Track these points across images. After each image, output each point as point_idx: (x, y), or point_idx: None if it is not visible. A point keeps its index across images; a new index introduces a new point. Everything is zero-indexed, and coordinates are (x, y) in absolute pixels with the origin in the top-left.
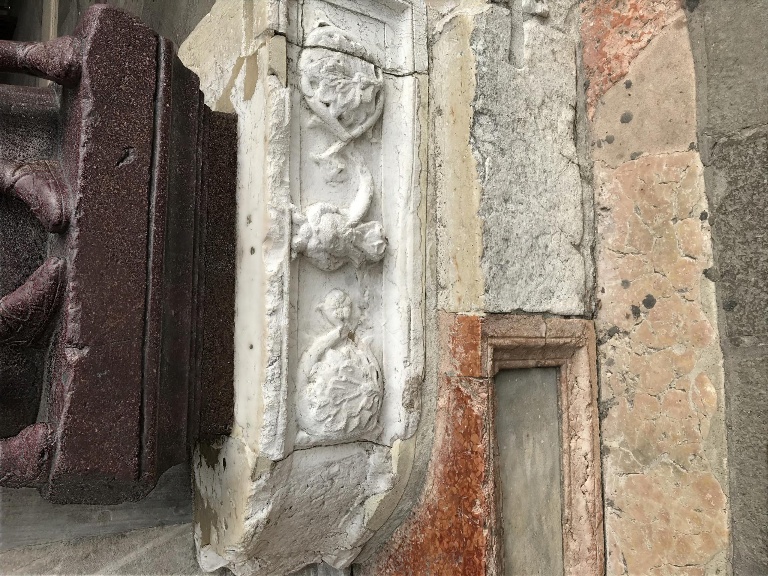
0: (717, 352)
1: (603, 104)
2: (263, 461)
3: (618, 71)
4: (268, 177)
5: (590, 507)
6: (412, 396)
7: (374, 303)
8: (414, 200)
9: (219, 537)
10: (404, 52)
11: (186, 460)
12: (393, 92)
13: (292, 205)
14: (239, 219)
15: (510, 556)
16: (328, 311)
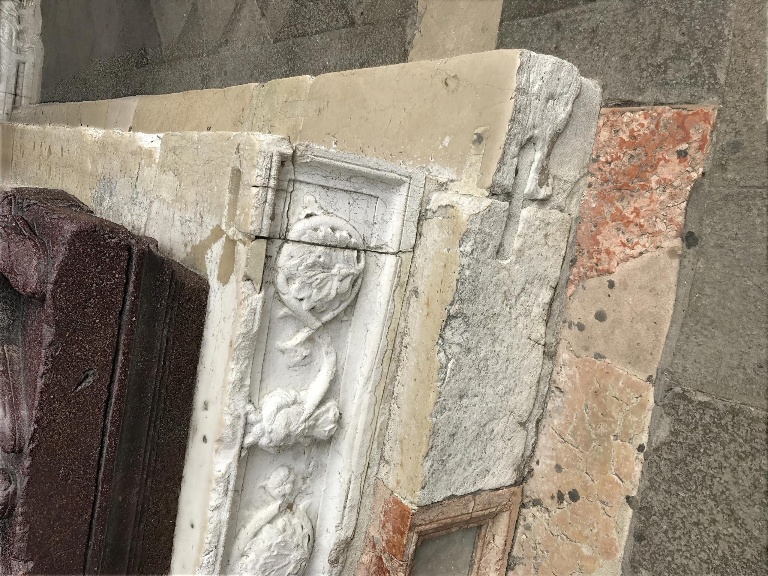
0: (617, 569)
1: (583, 289)
2: None
3: (605, 266)
4: (228, 383)
5: None
6: (338, 553)
7: (318, 471)
8: (374, 380)
9: None
10: (392, 229)
11: None
12: (373, 269)
13: (249, 408)
14: (197, 394)
15: None
16: (271, 489)
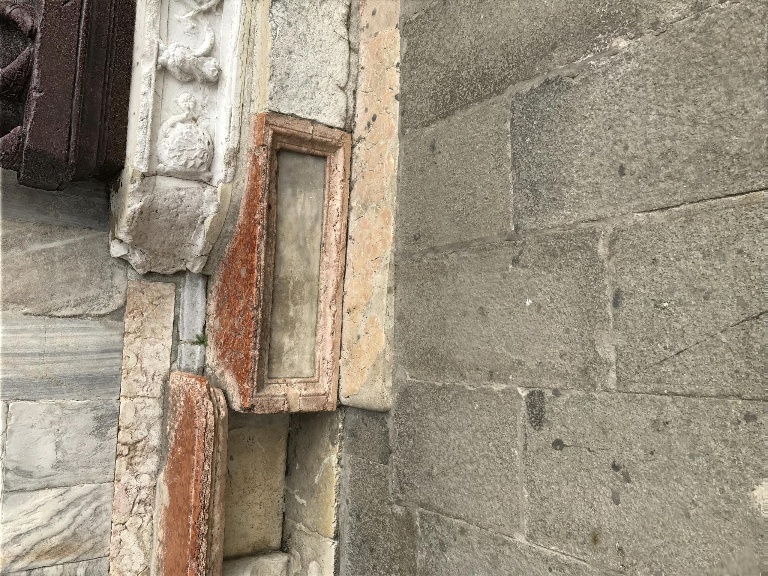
0: (396, 140)
1: (366, 5)
2: (137, 172)
3: None
4: (146, 23)
5: (337, 238)
6: (230, 159)
7: (211, 105)
8: (239, 49)
9: (118, 227)
10: None
11: (106, 197)
12: None
13: (159, 39)
14: (134, 49)
15: (282, 253)
16: (180, 103)
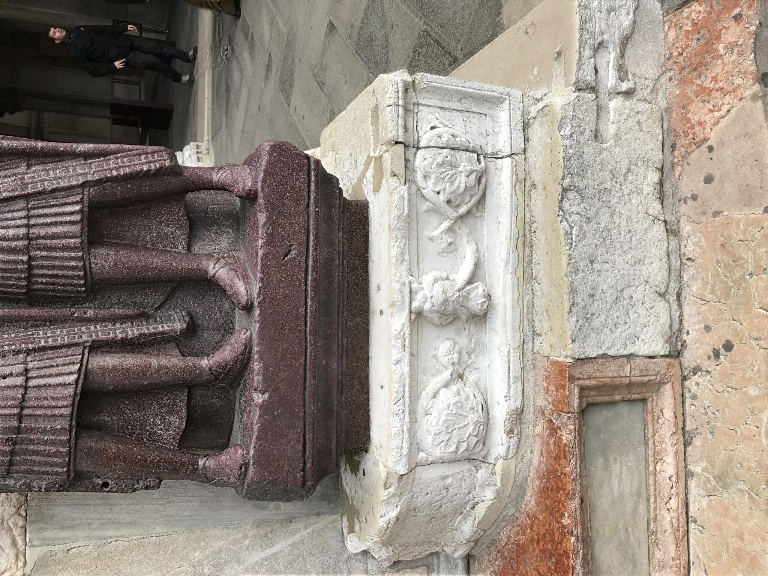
0: None
1: (688, 165)
2: (392, 475)
3: (701, 136)
4: (392, 257)
5: (674, 522)
6: (512, 424)
7: (480, 348)
8: (512, 262)
9: (361, 528)
10: (503, 137)
11: None
12: (494, 172)
13: (411, 278)
14: (371, 285)
15: (598, 559)
16: (441, 357)
